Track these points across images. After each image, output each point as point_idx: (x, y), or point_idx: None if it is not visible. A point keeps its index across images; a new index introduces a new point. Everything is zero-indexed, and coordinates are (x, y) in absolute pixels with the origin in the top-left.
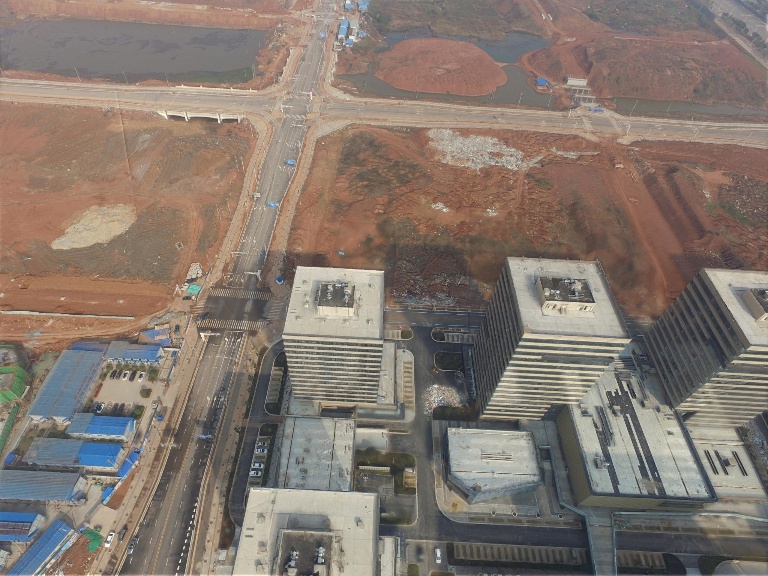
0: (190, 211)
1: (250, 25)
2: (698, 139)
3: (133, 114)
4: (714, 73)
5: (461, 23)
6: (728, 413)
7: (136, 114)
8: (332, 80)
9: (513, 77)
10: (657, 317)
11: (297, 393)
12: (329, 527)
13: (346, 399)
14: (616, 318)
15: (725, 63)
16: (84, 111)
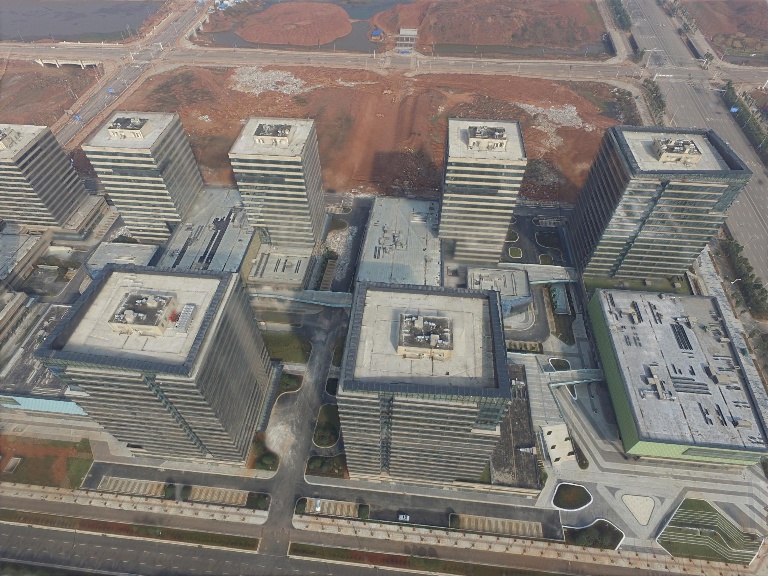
0: None
1: None
2: (480, 72)
3: (16, 63)
4: (537, 20)
5: None
6: (290, 229)
7: (19, 63)
8: (195, 36)
9: (356, 30)
10: (331, 190)
11: (3, 217)
12: None
13: (38, 223)
14: None
15: (558, 12)
16: None
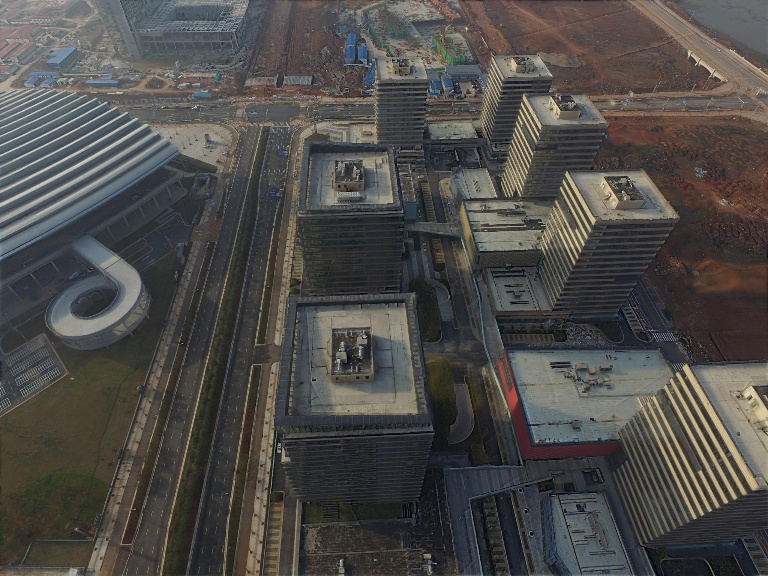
0: (597, 80)
1: None
2: None
3: (675, 45)
4: None
5: None
6: None
7: (677, 46)
8: None
9: None
10: (669, 313)
11: None
12: (413, 73)
13: None
14: None
15: None
16: (658, 31)
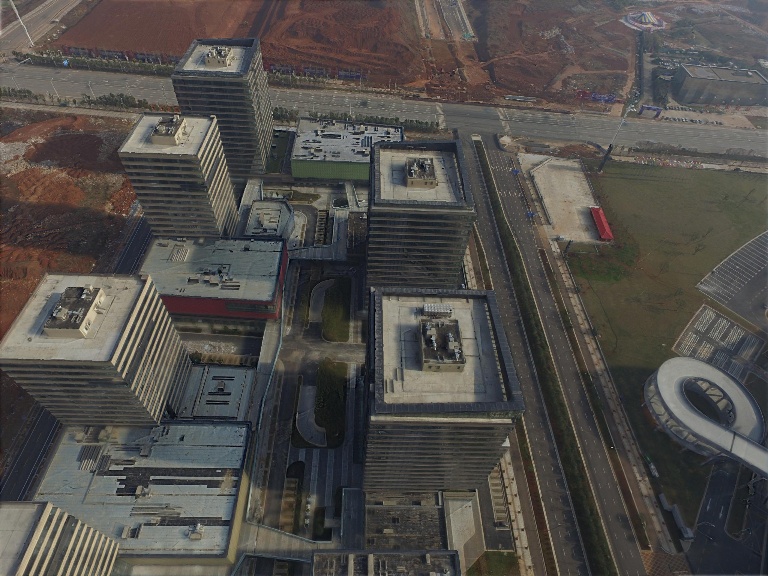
0: None
1: None
2: None
3: None
4: None
5: None
6: (177, 374)
7: None
8: None
9: None
10: None
11: None
12: None
13: None
14: (7, 510)
15: None
16: None
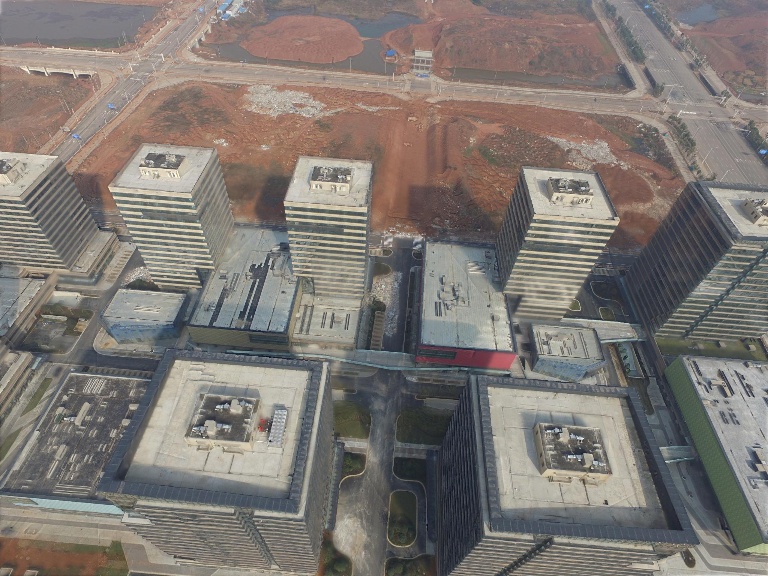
0: (7, 141)
1: (147, 2)
2: (504, 101)
3: None
4: (553, 48)
5: (347, 4)
6: (339, 280)
7: (1, 69)
8: (197, 47)
9: (368, 49)
10: None
11: None
12: None
13: (42, 265)
14: None
15: (571, 41)
16: None
